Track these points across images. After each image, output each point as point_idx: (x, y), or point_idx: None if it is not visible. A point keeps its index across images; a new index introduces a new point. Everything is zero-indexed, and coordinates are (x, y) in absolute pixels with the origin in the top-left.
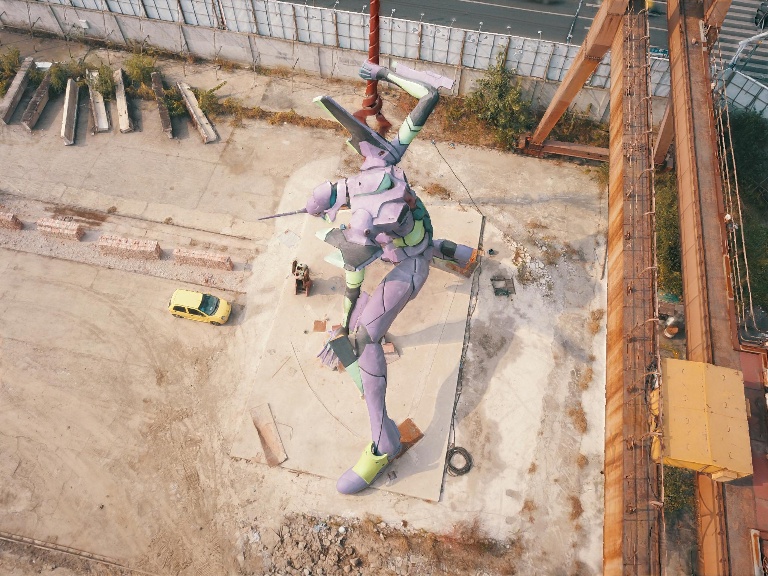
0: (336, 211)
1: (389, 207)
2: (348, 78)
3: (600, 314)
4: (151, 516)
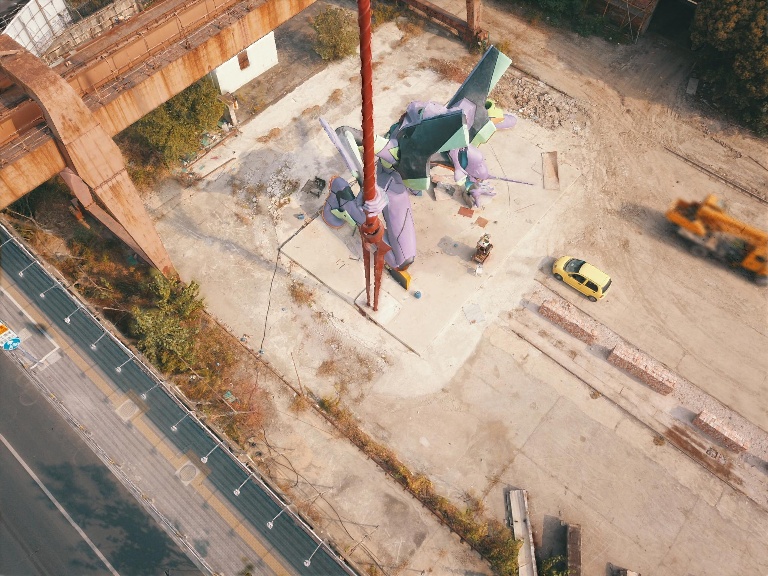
0: None
1: None
2: None
3: (262, 138)
4: (643, 165)
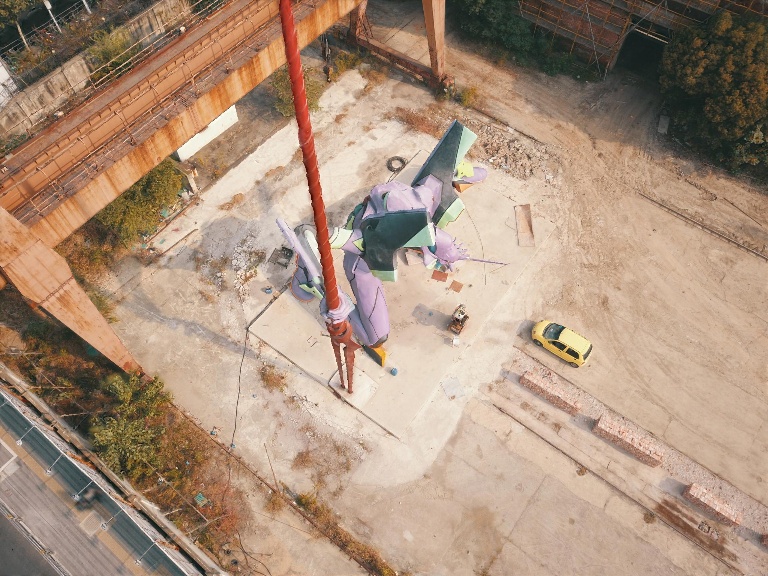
0: None
1: None
2: None
3: (224, 206)
4: (619, 213)
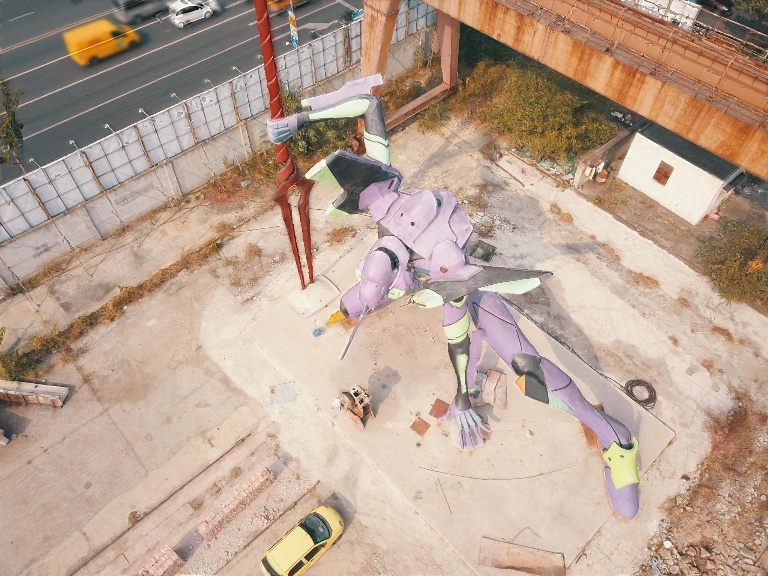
0: (402, 276)
1: (455, 221)
2: (134, 218)
3: (556, 207)
4: None
